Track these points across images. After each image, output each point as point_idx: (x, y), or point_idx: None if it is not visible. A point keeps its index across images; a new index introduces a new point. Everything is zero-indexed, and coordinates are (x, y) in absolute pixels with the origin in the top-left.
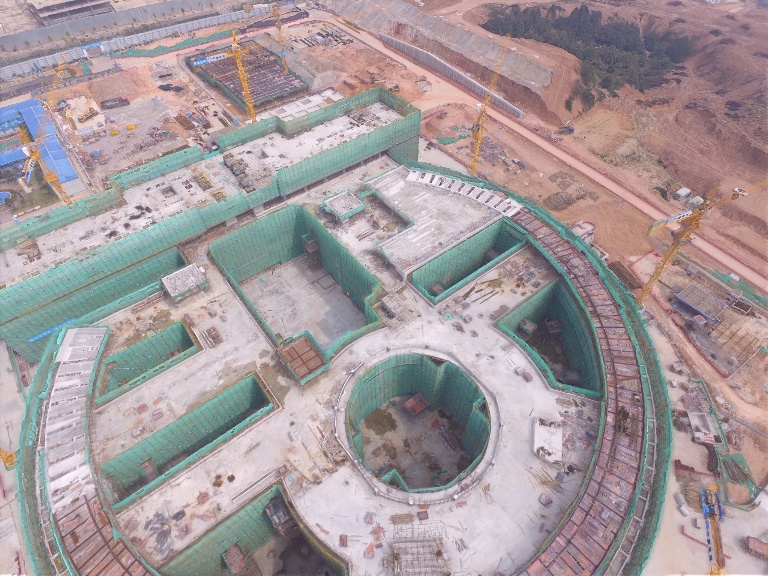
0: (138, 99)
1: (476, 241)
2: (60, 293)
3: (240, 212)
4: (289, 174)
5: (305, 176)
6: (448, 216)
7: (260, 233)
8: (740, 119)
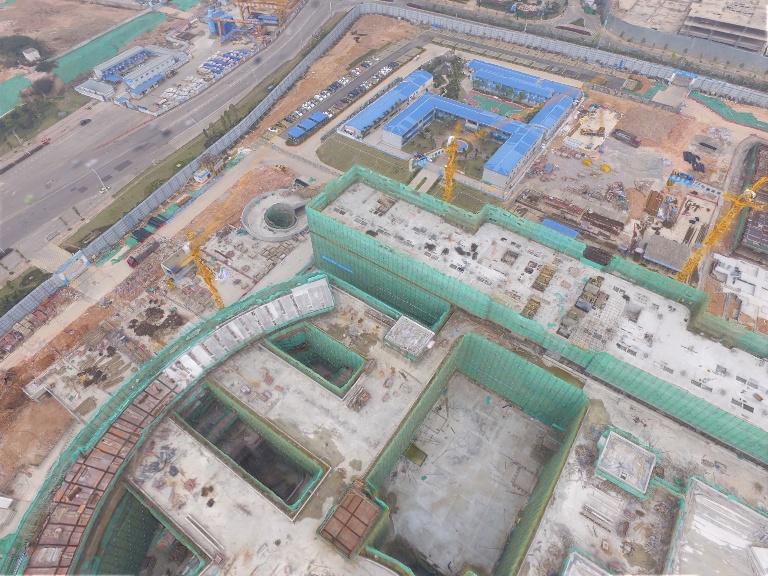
0: (650, 149)
1: None
2: (356, 250)
3: (530, 338)
4: (615, 365)
5: (634, 385)
6: None
7: (524, 372)
8: None
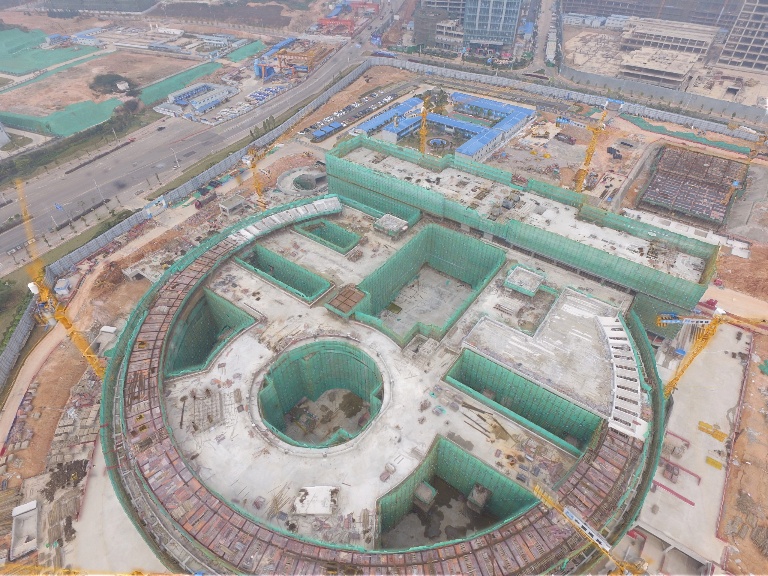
0: (583, 146)
1: (553, 402)
2: (358, 182)
3: (471, 225)
4: (521, 229)
5: (534, 242)
6: (568, 364)
7: (468, 249)
8: None
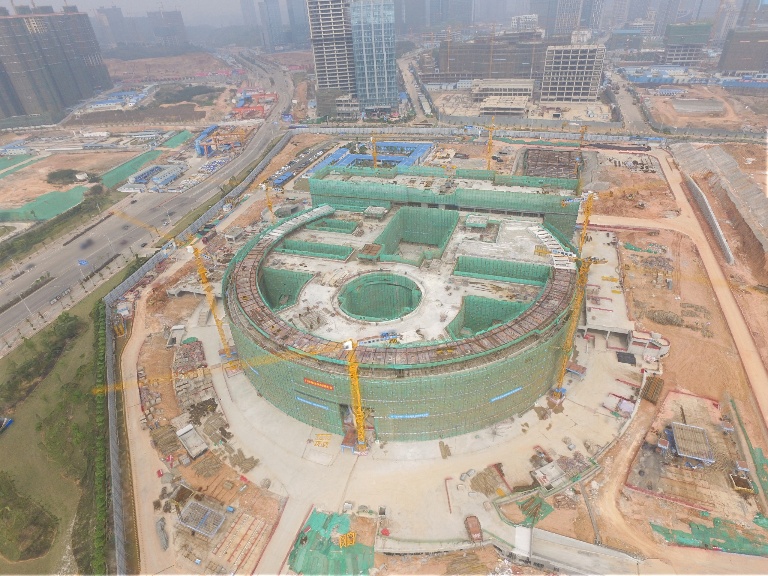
0: (475, 158)
1: (520, 269)
2: (338, 194)
3: (429, 202)
4: (464, 193)
5: (474, 200)
6: (521, 250)
7: (431, 217)
8: None
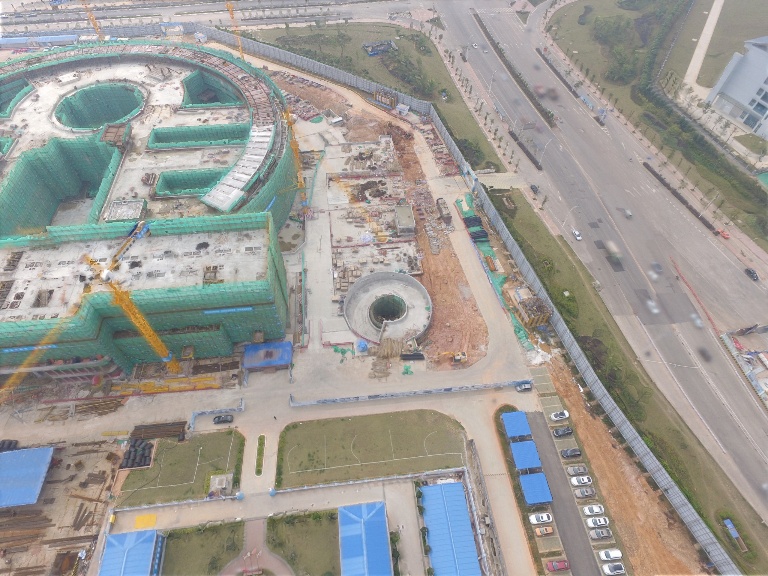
0: None
1: None
2: None
3: None
4: None
5: None
6: None
7: None
8: None
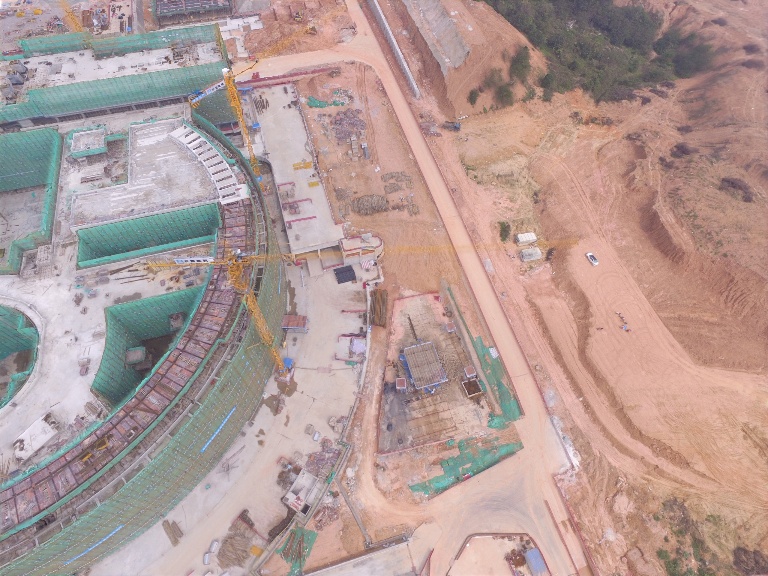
0: None
1: (178, 219)
2: None
3: None
4: (46, 96)
5: (70, 102)
6: (169, 184)
7: (16, 148)
8: (671, 170)
